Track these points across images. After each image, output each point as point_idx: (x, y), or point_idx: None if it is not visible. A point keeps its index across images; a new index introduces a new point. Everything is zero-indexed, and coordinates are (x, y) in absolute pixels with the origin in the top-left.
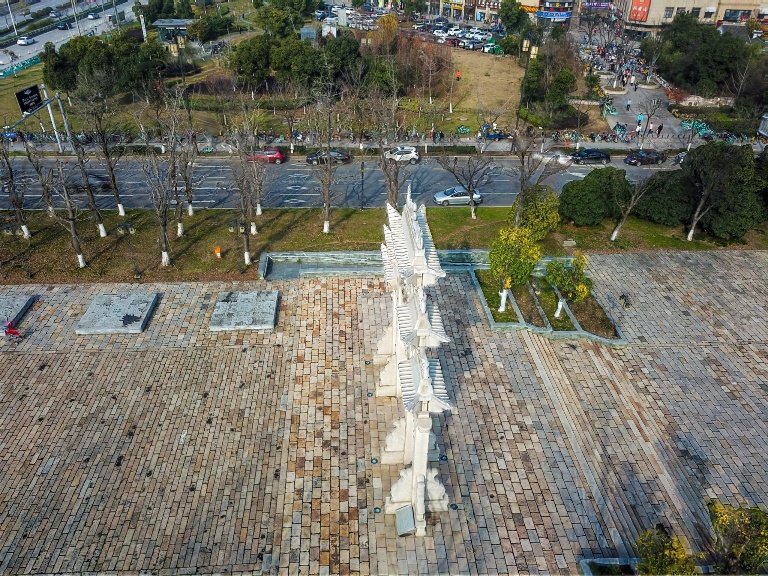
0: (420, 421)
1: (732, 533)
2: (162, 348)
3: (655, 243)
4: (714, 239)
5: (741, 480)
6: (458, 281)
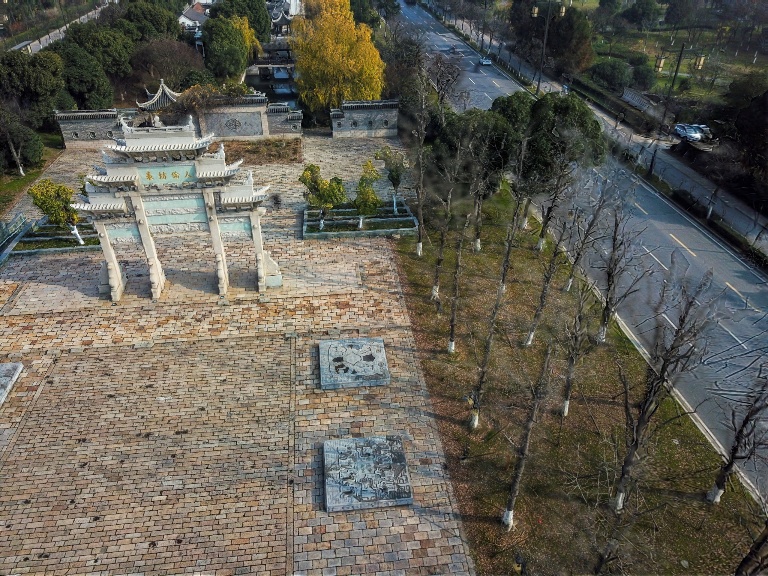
0: (260, 210)
1: (313, 178)
2: (7, 449)
3: (15, 188)
4: (32, 167)
5: None
6: (19, 262)
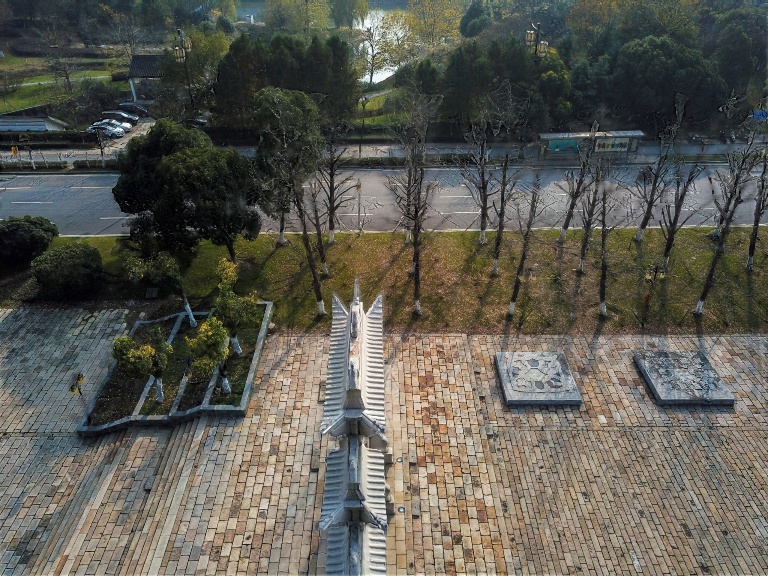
0: None
1: None
2: None
3: None
4: None
5: (2, 522)
6: None
